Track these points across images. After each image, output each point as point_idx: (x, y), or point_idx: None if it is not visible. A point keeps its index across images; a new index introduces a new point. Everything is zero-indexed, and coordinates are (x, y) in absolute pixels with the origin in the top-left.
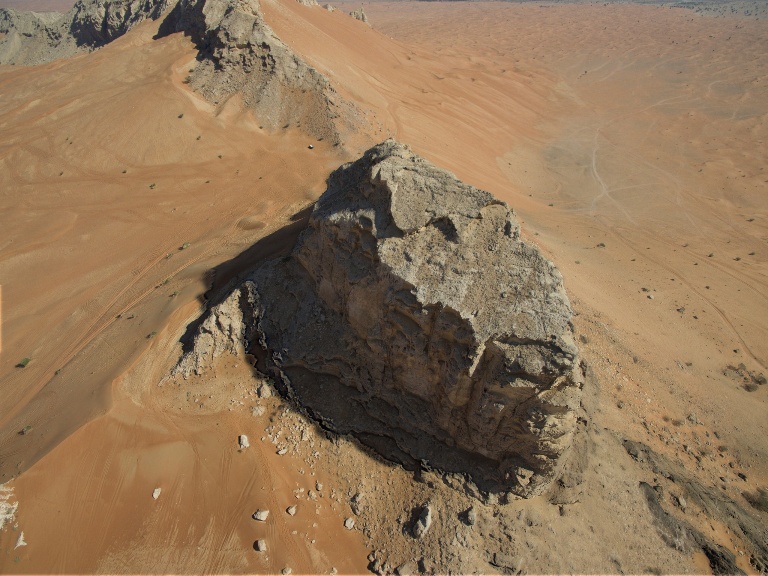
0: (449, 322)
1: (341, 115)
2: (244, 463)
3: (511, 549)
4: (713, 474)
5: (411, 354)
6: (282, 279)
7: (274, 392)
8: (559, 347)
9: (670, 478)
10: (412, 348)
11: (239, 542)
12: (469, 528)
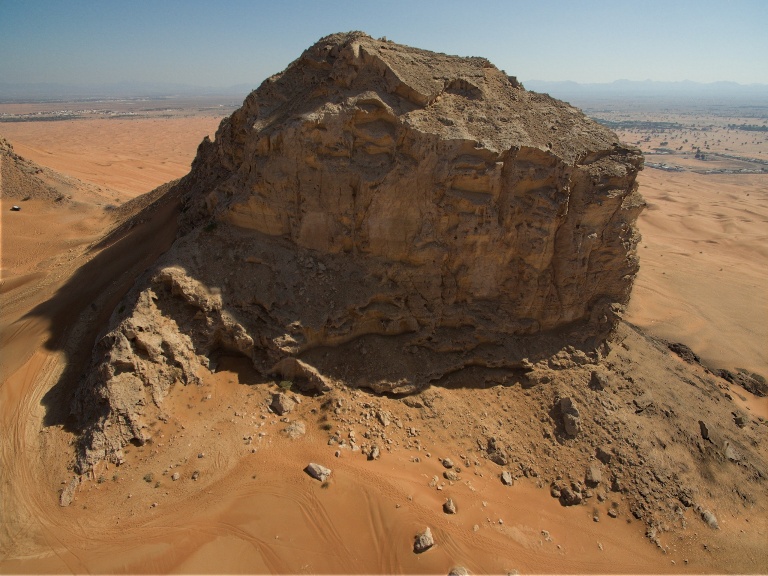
0: (524, 168)
1: (41, 172)
2: (344, 496)
3: (639, 389)
4: None
5: (487, 230)
6: (221, 251)
7: (297, 398)
8: (625, 149)
9: None
10: (487, 222)
11: None
12: (605, 392)
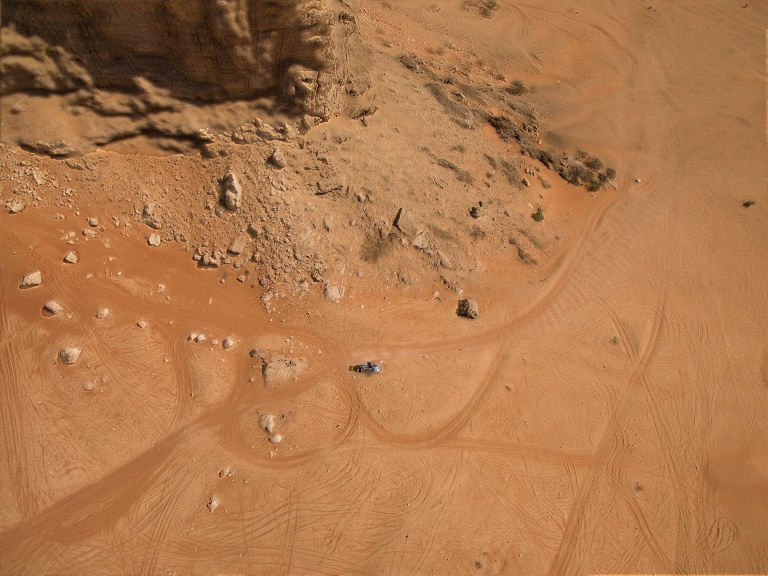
0: None
1: None
2: None
3: (331, 171)
4: (481, 84)
5: None
6: None
7: None
8: None
9: (449, 82)
10: None
11: (21, 321)
12: (282, 172)
